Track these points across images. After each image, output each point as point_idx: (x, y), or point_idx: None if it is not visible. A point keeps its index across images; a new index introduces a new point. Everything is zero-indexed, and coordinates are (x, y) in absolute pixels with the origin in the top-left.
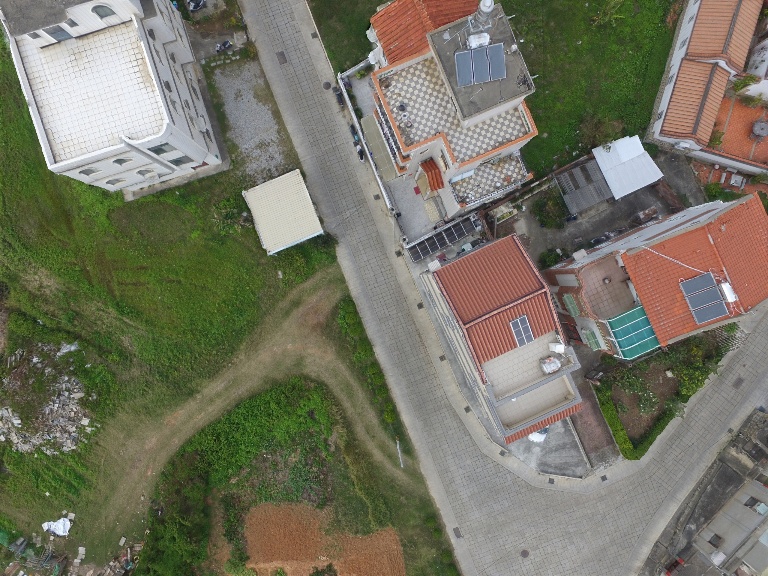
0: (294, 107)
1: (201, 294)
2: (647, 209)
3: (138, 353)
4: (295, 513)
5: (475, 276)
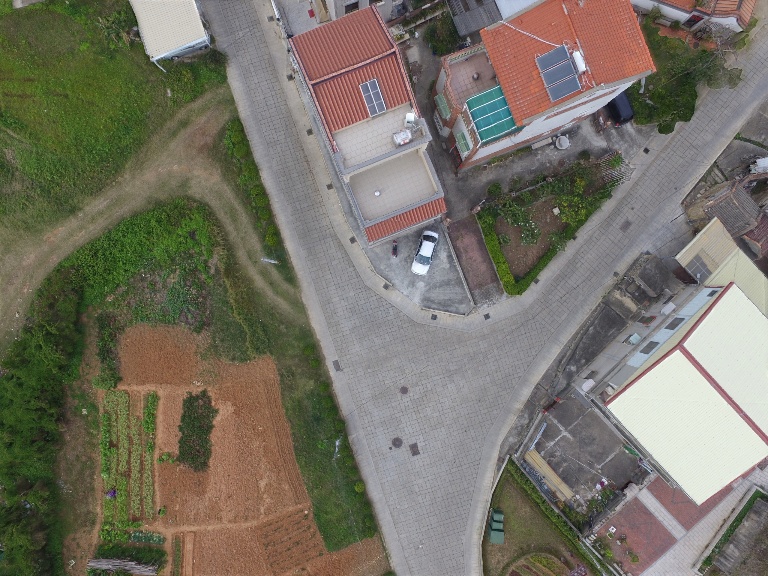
0: None
1: (88, 110)
2: None
3: (20, 166)
4: (171, 335)
5: (329, 41)
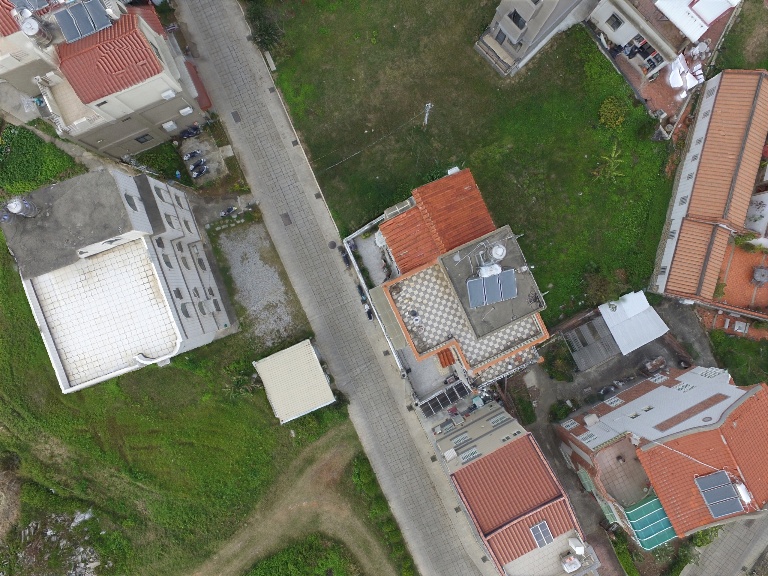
0: (300, 267)
1: (214, 455)
2: (654, 360)
3: (153, 517)
4: None
5: (493, 480)
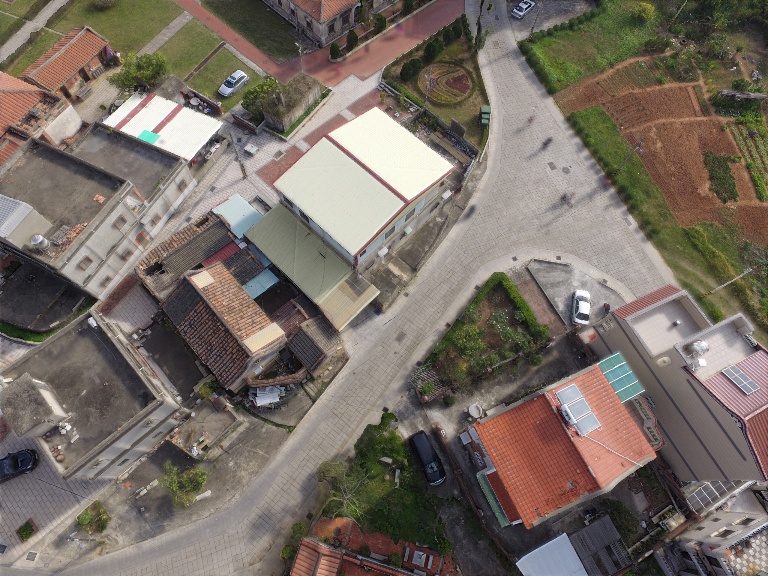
0: None
1: None
2: None
3: None
4: (767, 240)
5: None
